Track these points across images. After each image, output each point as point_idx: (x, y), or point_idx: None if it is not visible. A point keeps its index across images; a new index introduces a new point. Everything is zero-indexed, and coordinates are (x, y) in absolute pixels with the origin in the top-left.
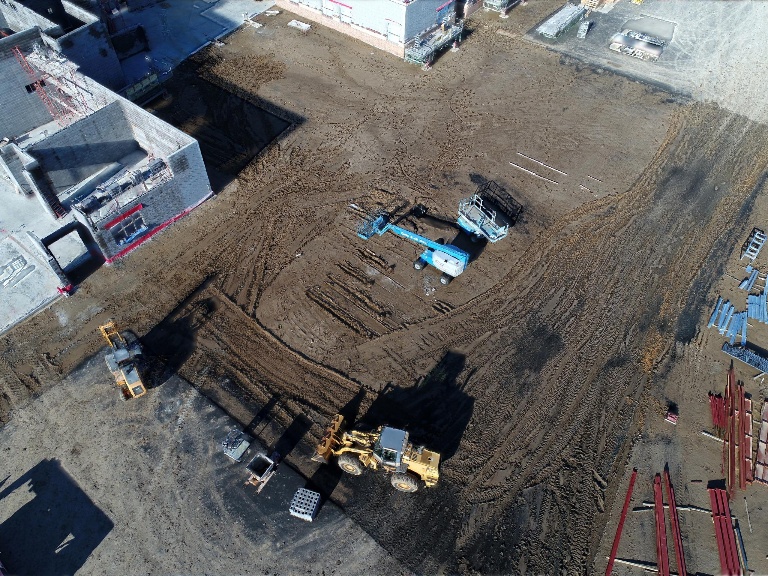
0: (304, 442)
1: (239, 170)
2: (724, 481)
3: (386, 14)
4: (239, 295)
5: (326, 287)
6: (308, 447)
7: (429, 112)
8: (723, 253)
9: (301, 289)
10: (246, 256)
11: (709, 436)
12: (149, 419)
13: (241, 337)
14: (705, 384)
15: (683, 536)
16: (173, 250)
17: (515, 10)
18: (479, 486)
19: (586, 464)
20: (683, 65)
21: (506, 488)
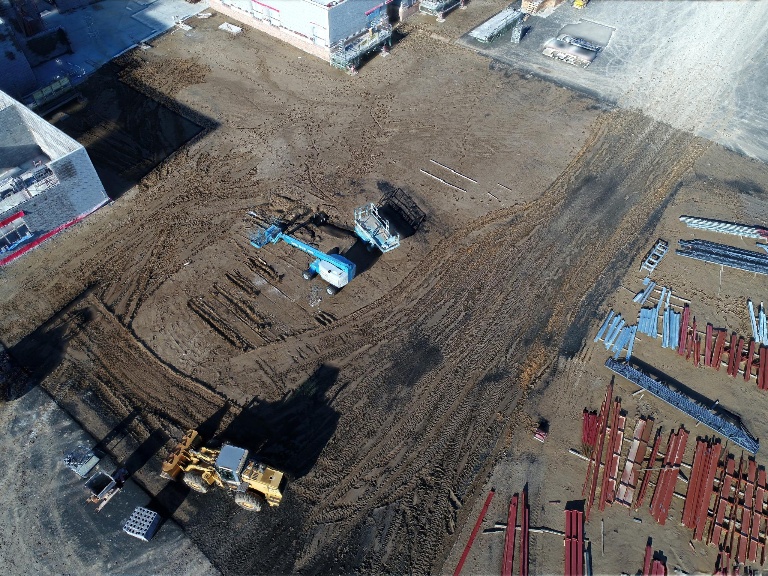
0: (156, 458)
1: (142, 176)
2: (584, 502)
3: (311, 18)
4: (118, 305)
5: (209, 297)
6: (160, 463)
7: (347, 117)
8: (622, 265)
9: (183, 299)
10: (133, 264)
11: (576, 455)
12: (1, 433)
13: (113, 348)
14: (581, 400)
15: (531, 559)
16: (59, 258)
17: (453, 14)
18: (329, 505)
19: (444, 483)
20: (614, 71)
21: (357, 507)
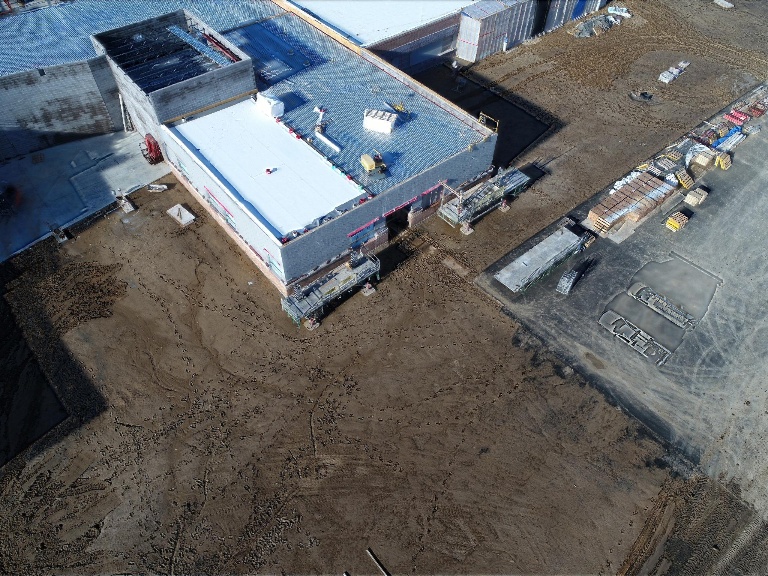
0: None
1: None
2: None
3: (264, 244)
4: None
5: None
6: None
7: (274, 422)
8: None
9: None
10: None
11: None
12: None
13: None
14: None
15: None
16: None
17: (487, 219)
18: None
19: None
20: (706, 380)
21: None
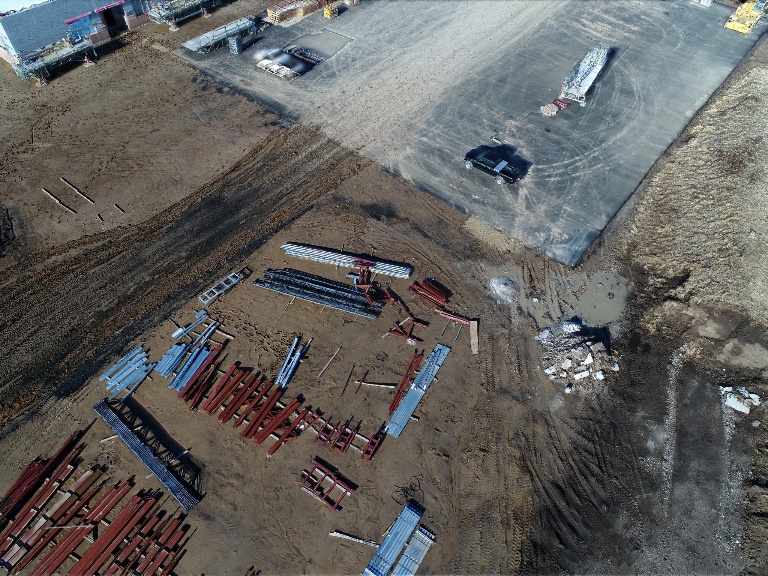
0: None
1: None
2: None
3: None
4: None
5: None
6: None
7: (5, 132)
8: (187, 295)
9: None
10: None
11: None
12: None
13: None
14: (41, 447)
15: None
16: None
17: (192, 22)
18: None
19: None
20: (319, 85)
21: None
